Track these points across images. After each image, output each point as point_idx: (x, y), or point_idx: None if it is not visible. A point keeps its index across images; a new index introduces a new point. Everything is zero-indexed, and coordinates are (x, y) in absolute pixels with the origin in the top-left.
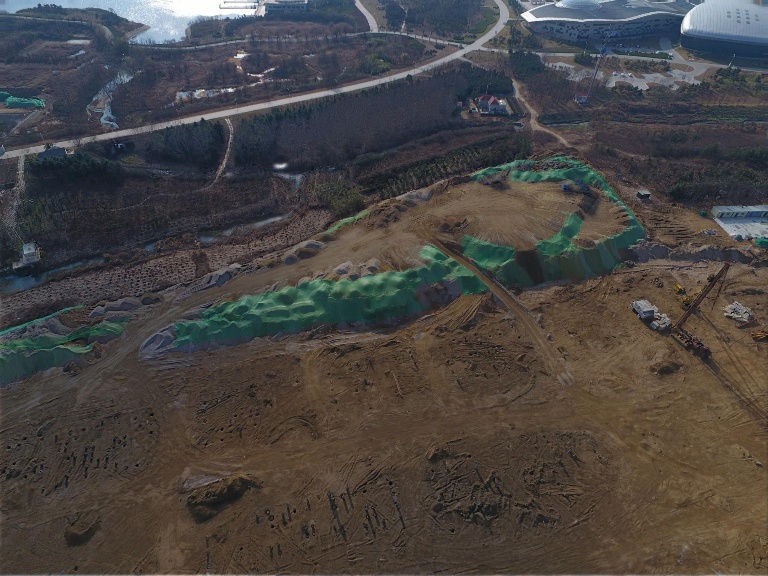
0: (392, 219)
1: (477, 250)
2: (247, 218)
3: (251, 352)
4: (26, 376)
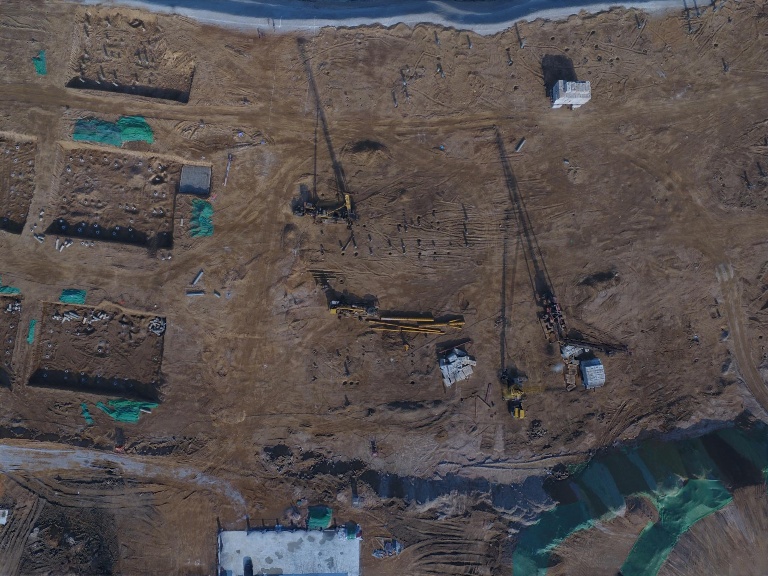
0: None
1: None
2: None
3: None
4: None
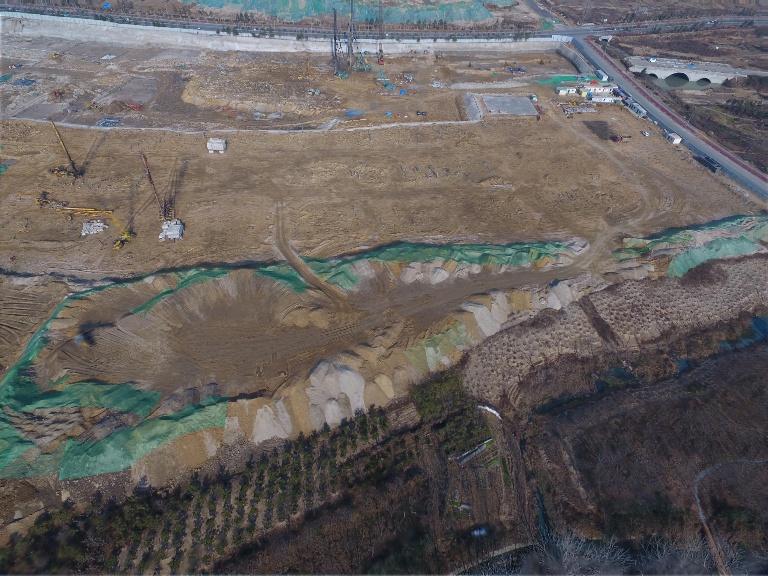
0: (380, 330)
1: (293, 281)
2: (586, 404)
3: (503, 237)
4: (654, 235)
